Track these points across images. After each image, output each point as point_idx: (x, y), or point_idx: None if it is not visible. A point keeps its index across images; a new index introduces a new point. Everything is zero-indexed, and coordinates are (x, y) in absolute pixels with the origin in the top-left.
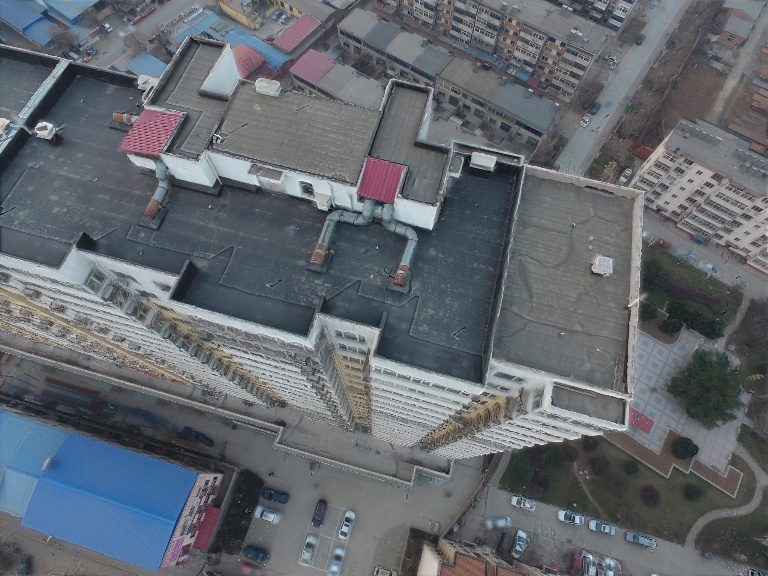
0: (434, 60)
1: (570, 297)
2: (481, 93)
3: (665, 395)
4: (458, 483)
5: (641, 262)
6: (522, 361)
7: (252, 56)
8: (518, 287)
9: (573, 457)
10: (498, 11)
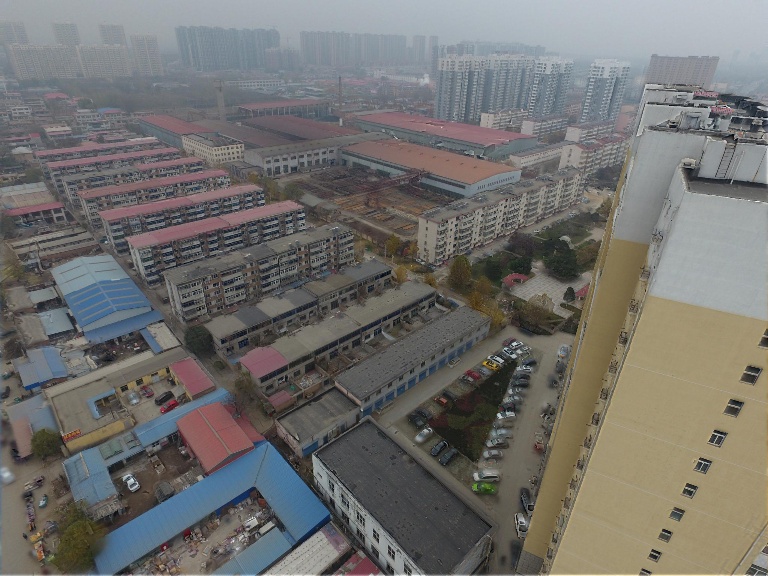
0: (300, 296)
1: None
2: (346, 283)
3: (566, 283)
4: None
5: (486, 268)
6: None
7: (209, 409)
8: None
9: None
10: (290, 250)
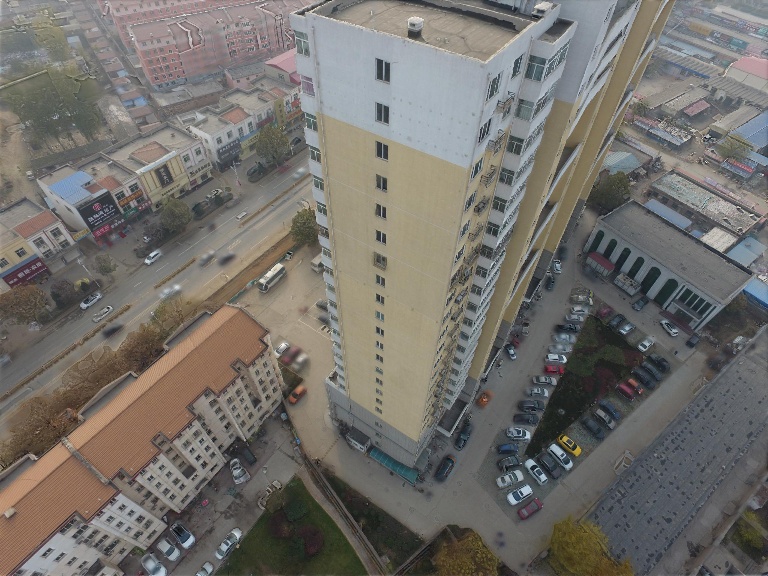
0: None
1: (398, 23)
2: None
3: None
4: (318, 434)
5: None
6: (364, 2)
7: None
8: (419, 9)
9: (283, 568)
10: None
